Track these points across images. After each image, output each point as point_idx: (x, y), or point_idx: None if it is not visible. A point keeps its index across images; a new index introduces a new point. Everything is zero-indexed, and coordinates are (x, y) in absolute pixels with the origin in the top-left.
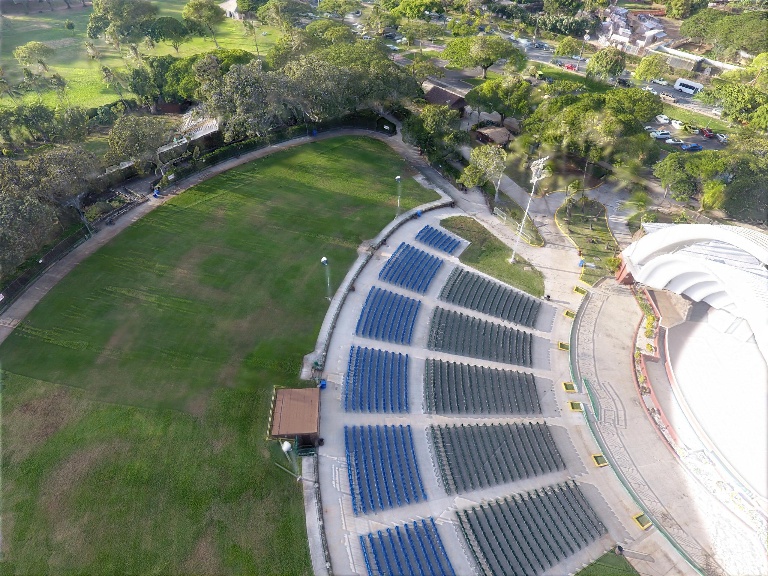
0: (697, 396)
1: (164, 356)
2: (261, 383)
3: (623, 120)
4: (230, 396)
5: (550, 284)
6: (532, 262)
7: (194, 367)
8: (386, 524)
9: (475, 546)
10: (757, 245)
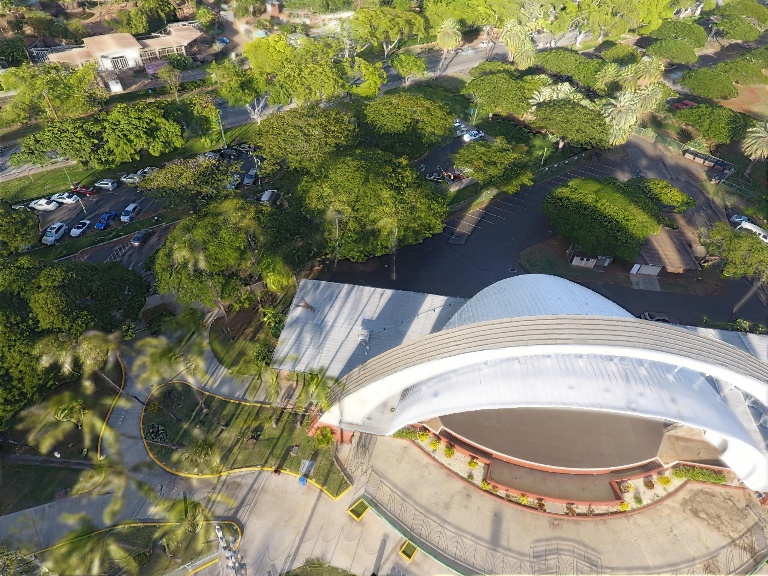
0: (545, 449)
1: None
2: None
3: (58, 284)
4: None
5: (339, 557)
6: (279, 570)
7: None
8: None
9: None
10: (567, 346)
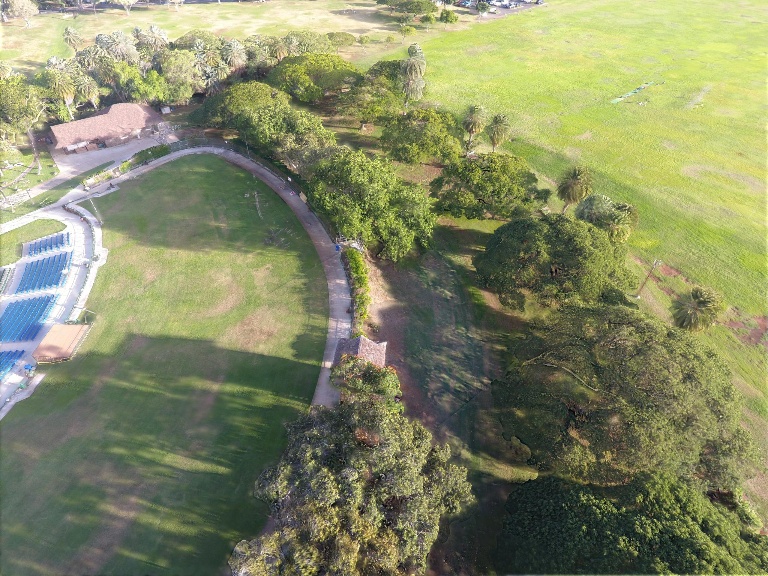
0: None
1: (162, 386)
2: (81, 364)
3: None
4: (111, 351)
5: None
6: None
7: (136, 376)
8: (45, 293)
9: (2, 284)
10: None
